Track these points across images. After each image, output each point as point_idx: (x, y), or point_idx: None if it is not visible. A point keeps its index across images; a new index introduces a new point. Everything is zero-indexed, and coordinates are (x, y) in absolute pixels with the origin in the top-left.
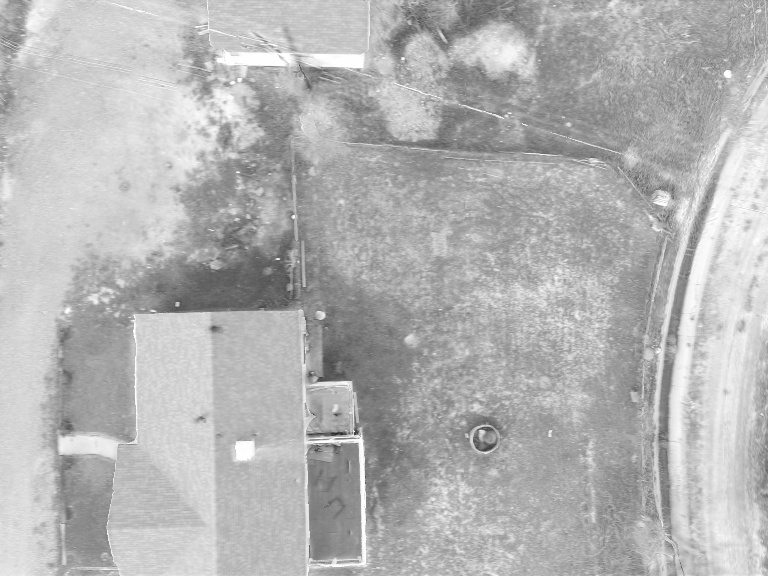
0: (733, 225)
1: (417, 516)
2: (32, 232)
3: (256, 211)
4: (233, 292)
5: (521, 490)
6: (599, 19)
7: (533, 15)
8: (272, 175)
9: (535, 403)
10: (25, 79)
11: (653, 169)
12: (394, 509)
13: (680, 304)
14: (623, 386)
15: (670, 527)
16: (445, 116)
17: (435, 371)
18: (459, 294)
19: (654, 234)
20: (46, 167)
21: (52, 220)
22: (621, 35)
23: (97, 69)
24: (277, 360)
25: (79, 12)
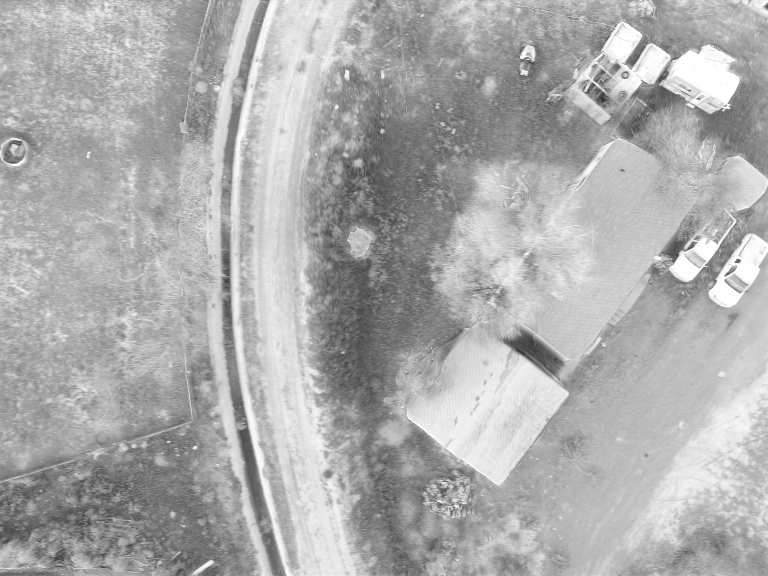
0: None
1: None
2: None
3: None
4: None
5: (53, 207)
6: None
7: None
8: None
9: (75, 124)
10: None
11: None
12: None
13: (252, 50)
14: (174, 118)
15: (229, 269)
16: None
17: None
18: (0, 11)
19: None
20: None
21: None
22: None
23: None
24: None
25: None
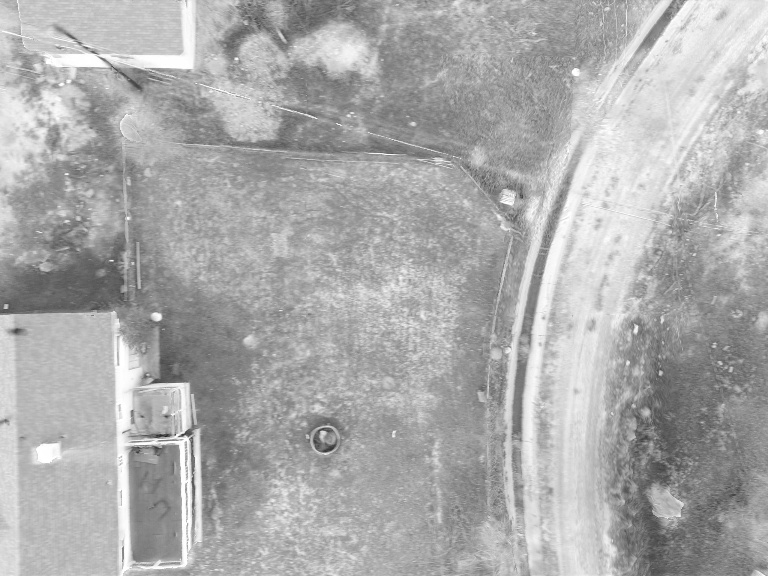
0: (584, 224)
1: (256, 517)
2: None
3: (86, 213)
4: (64, 294)
5: (364, 491)
6: (443, 18)
7: (375, 14)
8: (104, 177)
9: (378, 404)
10: None
11: (500, 168)
12: (233, 511)
13: (534, 303)
14: (471, 386)
15: (524, 527)
16: (285, 116)
17: (275, 372)
18: (300, 295)
19: (502, 233)
20: None
21: None
22: (467, 34)
23: None
24: (87, 362)
25: None
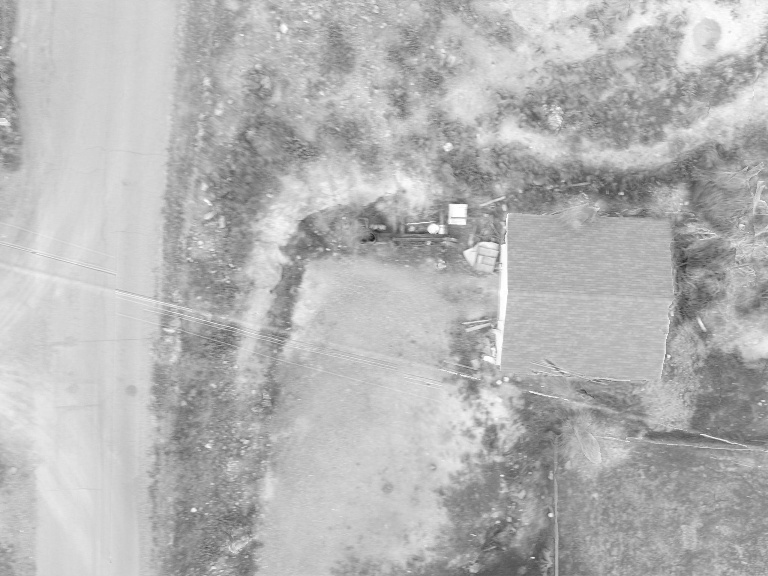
0: None
1: None
2: (293, 533)
3: (517, 514)
4: None
5: None
6: None
7: None
8: (532, 474)
9: None
10: (290, 374)
11: None
12: None
13: None
14: None
15: None
16: (700, 405)
17: None
18: None
19: None
20: (309, 466)
21: (313, 521)
22: None
23: (363, 365)
24: None
25: (345, 305)
